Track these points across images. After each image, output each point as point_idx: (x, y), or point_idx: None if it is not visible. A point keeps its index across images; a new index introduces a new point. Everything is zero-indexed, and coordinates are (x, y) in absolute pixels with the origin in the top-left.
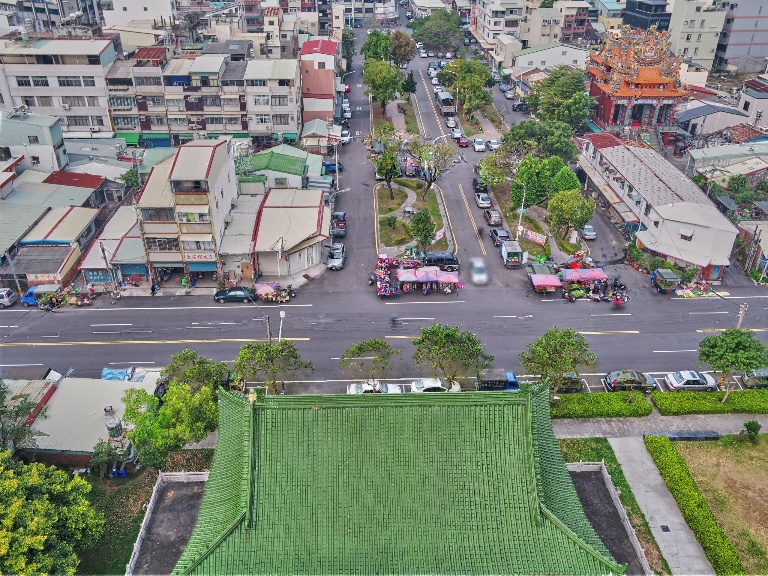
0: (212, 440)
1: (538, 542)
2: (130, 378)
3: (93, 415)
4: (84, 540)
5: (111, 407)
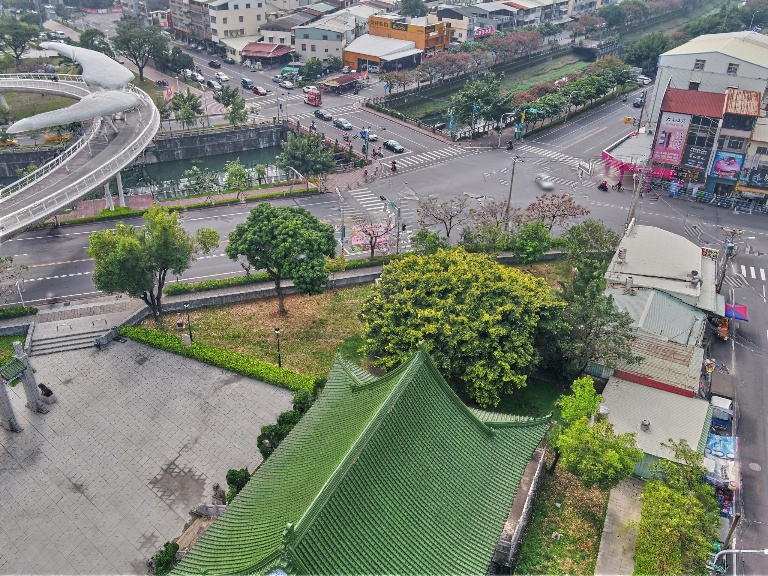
0: (619, 524)
1: (194, 575)
2: (720, 457)
3: (644, 418)
4: (471, 389)
5: (648, 425)
